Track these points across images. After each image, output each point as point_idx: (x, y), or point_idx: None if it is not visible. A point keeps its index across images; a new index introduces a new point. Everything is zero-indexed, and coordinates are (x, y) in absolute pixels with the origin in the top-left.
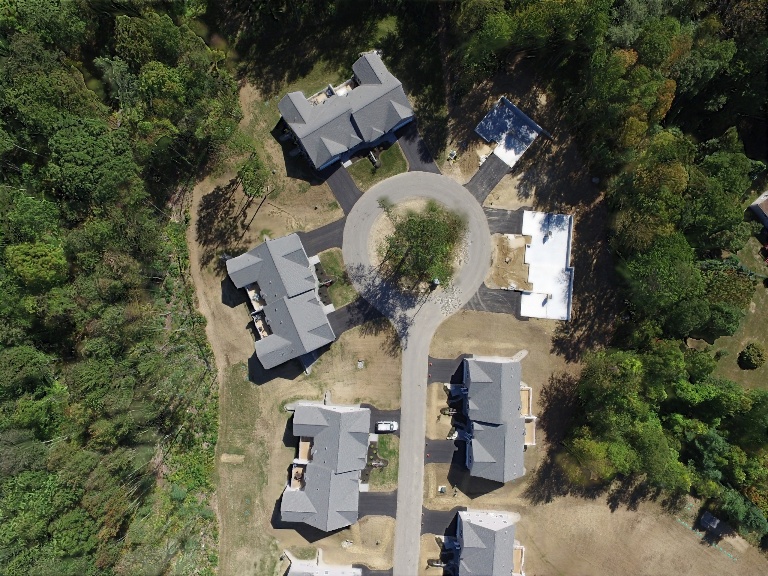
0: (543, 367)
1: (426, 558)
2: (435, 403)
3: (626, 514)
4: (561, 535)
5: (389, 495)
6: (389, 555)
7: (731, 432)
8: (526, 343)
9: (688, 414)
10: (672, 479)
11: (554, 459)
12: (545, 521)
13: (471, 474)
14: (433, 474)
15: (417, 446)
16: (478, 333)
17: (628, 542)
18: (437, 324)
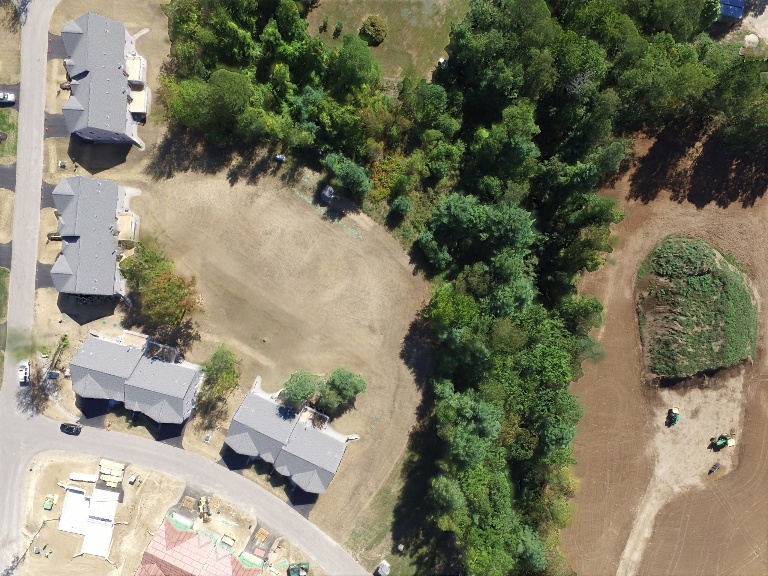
0: (164, 44)
1: (46, 233)
2: (55, 79)
3: (245, 188)
4: (180, 209)
5: (8, 168)
6: (9, 229)
7: (331, 90)
8: (148, 22)
9: (299, 82)
10: (245, 113)
11: (174, 135)
12: (166, 197)
13: (68, 129)
14: (53, 149)
15: (36, 120)
16: (100, 12)
17: (247, 216)
18: (57, 1)
